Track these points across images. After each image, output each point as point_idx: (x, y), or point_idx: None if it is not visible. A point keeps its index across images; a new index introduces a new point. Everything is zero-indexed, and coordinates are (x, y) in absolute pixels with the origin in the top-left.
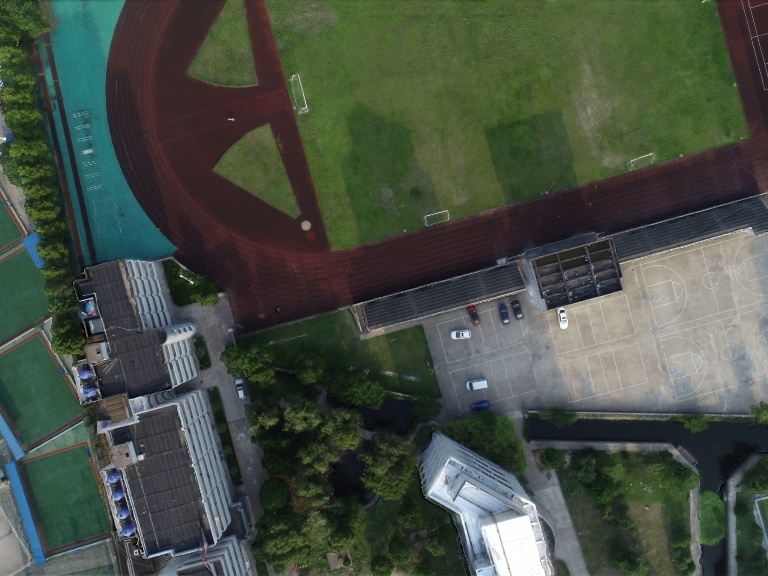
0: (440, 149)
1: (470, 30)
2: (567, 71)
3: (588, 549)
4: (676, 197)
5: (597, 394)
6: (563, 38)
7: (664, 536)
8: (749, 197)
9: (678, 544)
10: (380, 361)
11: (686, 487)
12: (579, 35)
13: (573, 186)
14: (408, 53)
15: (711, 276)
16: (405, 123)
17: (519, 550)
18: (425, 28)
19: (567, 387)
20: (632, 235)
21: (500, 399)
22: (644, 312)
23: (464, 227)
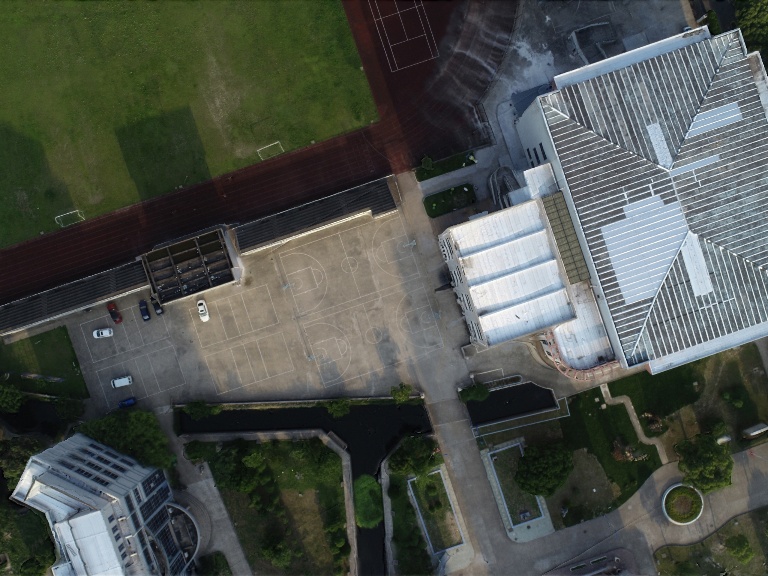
0: (71, 149)
1: (93, 29)
2: (192, 64)
3: (245, 539)
4: (310, 184)
5: (244, 385)
6: (186, 31)
7: (320, 522)
8: (375, 180)
9: (327, 529)
10: (26, 364)
11: (324, 472)
12: (202, 27)
13: (207, 179)
14: (32, 55)
15: (350, 261)
16: (34, 125)
17: (94, 545)
18: (48, 29)
19: (214, 379)
20: (262, 224)
21: (148, 395)
22: (286, 300)
23: (100, 226)
